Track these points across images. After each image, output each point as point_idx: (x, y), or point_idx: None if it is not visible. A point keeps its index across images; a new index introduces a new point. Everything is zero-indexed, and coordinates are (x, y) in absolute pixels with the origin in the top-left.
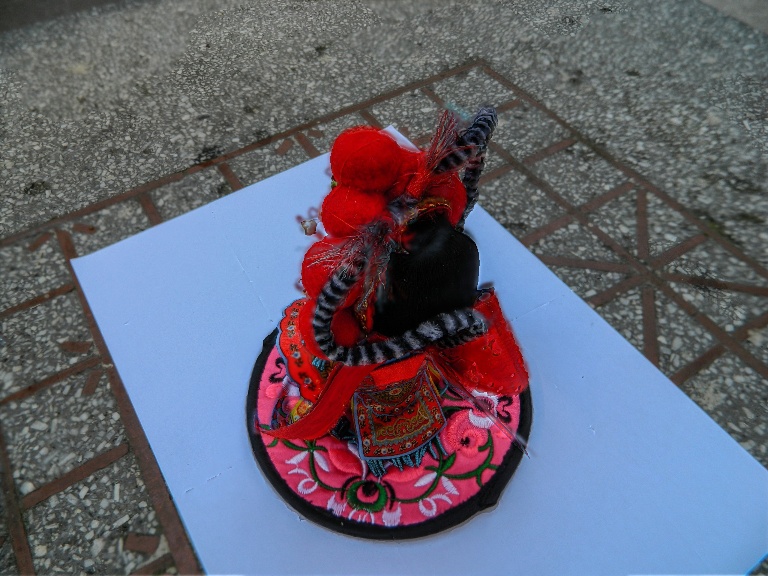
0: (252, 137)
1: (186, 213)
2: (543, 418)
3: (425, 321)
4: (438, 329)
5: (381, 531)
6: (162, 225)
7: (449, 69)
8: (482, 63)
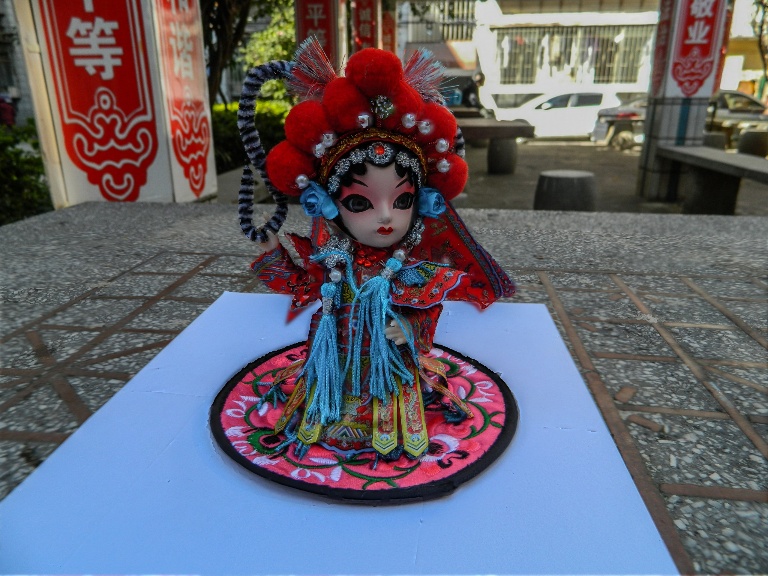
0: None
1: None
2: None
3: None
4: None
5: (449, 350)
6: None
7: None
8: None
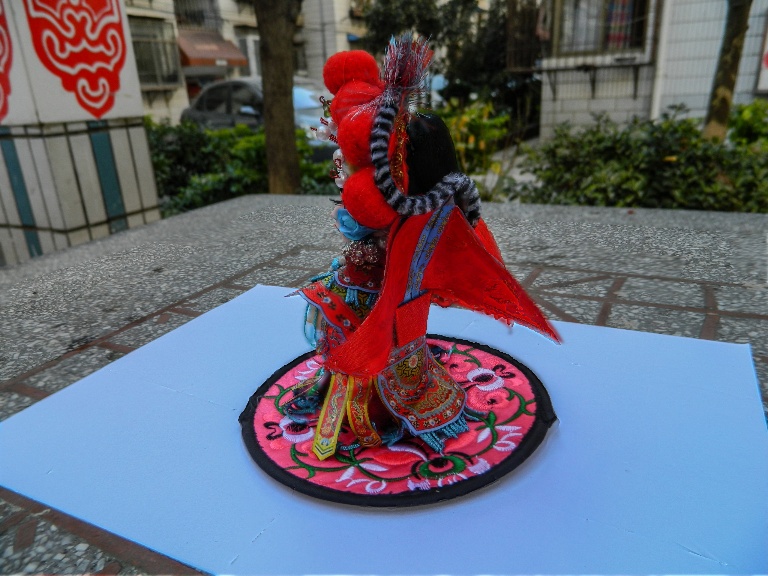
0: (124, 322)
1: (79, 381)
2: (535, 373)
3: (445, 175)
4: (458, 175)
5: (480, 478)
6: (52, 396)
7: (282, 254)
8: (306, 247)
